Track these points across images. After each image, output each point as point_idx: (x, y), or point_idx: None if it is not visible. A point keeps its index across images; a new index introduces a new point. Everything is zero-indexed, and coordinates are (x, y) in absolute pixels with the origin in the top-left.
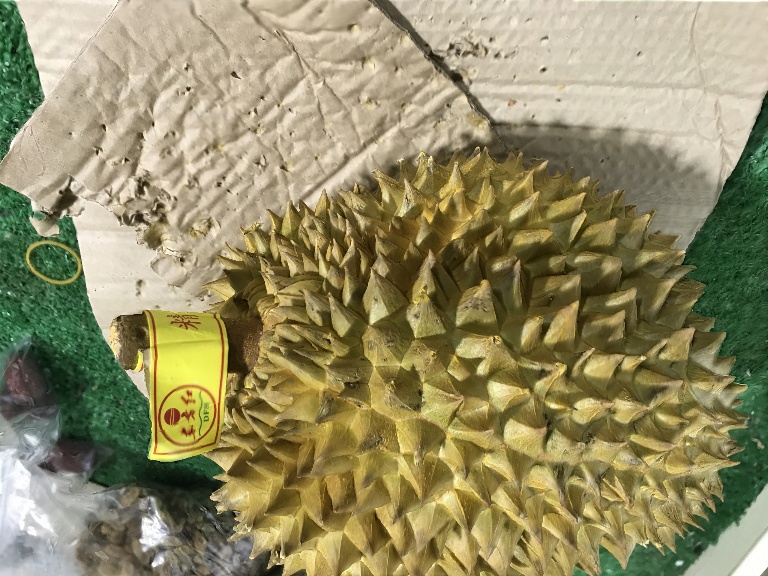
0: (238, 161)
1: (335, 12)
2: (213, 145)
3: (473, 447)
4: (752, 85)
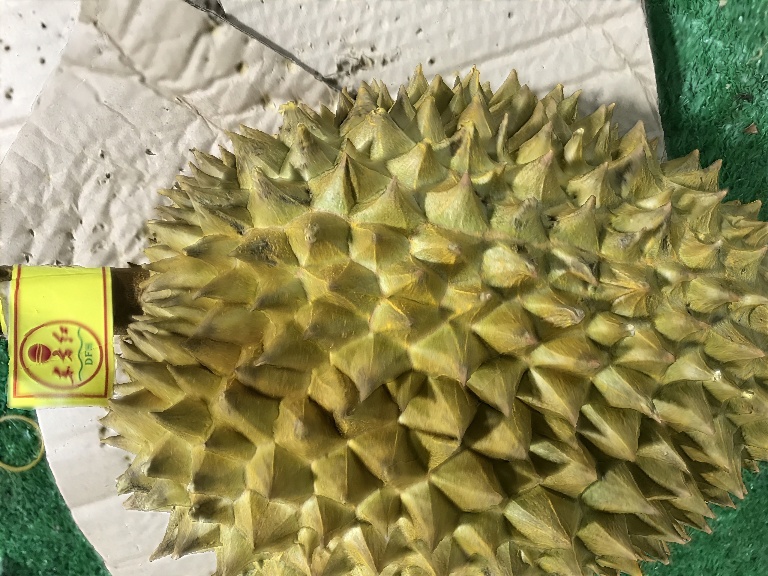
0: None
1: (219, 54)
2: (143, 230)
3: (388, 229)
4: None
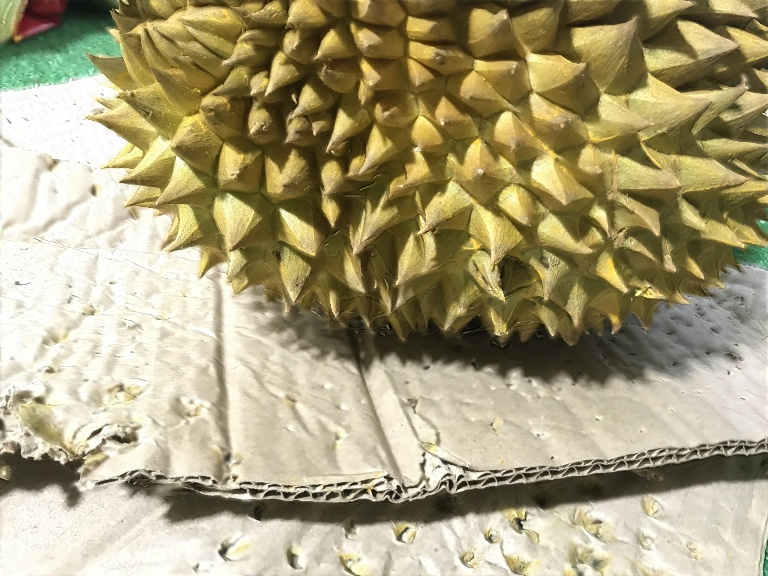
0: (100, 339)
1: (67, 183)
2: (51, 339)
3: None
4: None
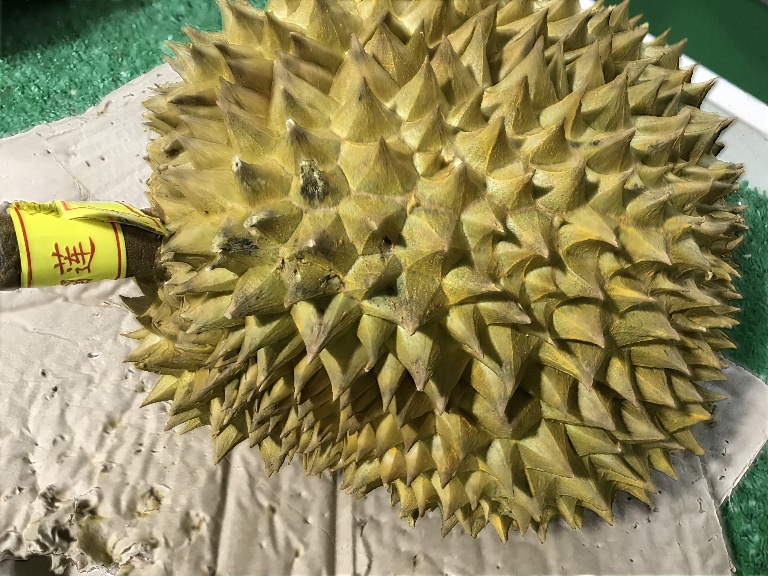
0: (145, 424)
1: None
2: (109, 424)
3: None
4: None
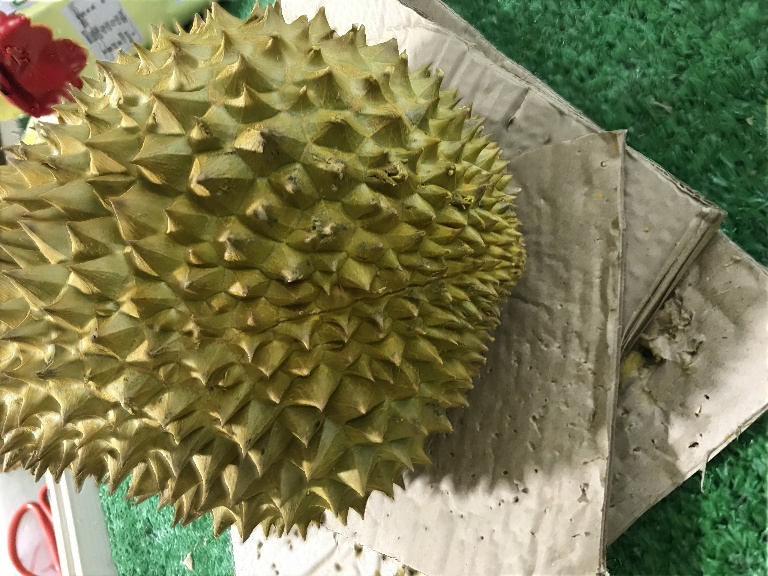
0: None
1: None
2: None
3: None
4: (378, 2)
